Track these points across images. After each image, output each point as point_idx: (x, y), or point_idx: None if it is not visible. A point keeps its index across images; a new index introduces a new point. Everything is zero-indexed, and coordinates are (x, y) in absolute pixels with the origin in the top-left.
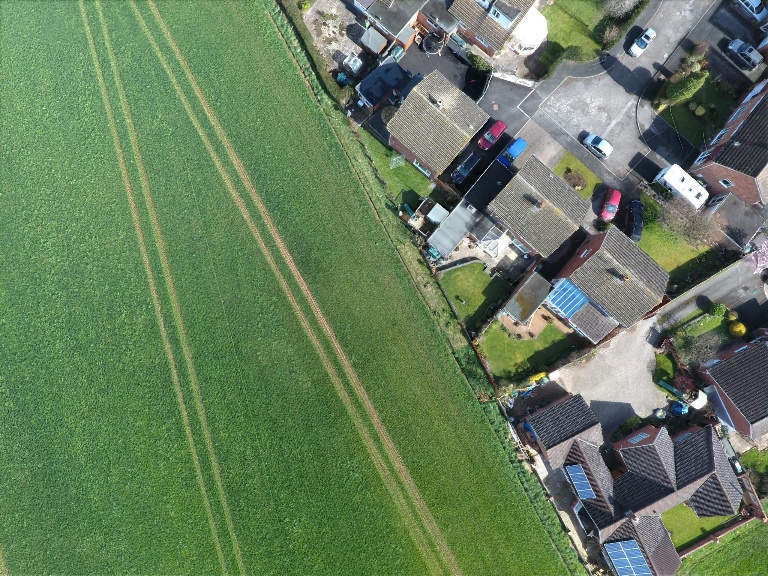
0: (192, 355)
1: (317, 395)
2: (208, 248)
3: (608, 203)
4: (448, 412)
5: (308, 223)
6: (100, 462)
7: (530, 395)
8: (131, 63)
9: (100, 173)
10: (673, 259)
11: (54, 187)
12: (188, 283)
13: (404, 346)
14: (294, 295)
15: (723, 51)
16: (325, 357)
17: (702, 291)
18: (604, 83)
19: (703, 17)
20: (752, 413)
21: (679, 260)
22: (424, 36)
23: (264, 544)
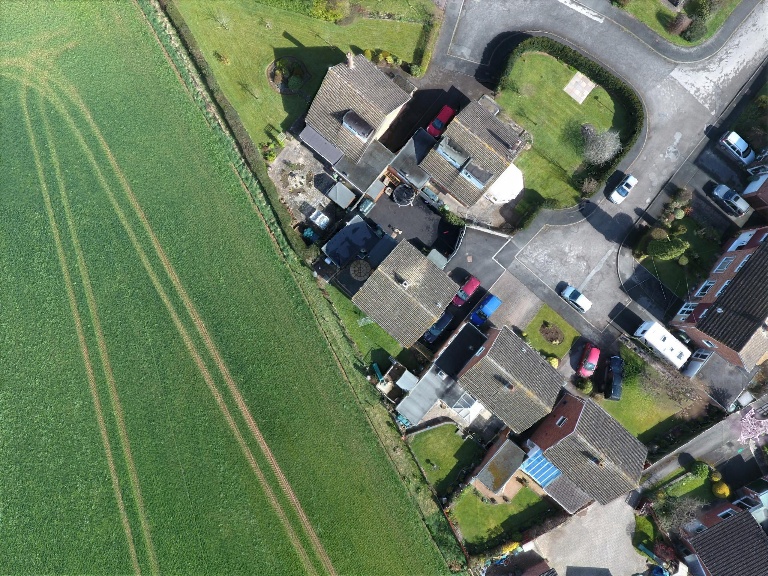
0: (151, 529)
1: (281, 567)
2: (168, 415)
3: (586, 361)
4: None
5: (273, 386)
6: None
7: (503, 564)
8: (89, 222)
9: (56, 339)
10: (654, 415)
11: (8, 355)
12: (147, 453)
13: (372, 513)
14: (258, 462)
15: (708, 195)
16: (290, 527)
17: (685, 448)
18: (583, 231)
19: (688, 159)
20: None
21: (661, 416)
22: (395, 186)
23: None
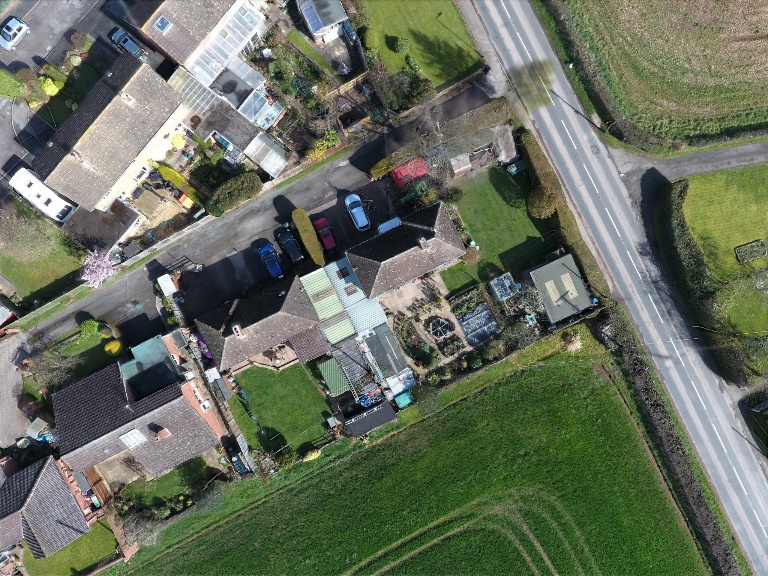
0: None
1: None
2: None
3: None
4: None
5: None
6: None
7: None
8: None
9: None
10: (50, 272)
11: None
12: None
13: None
14: None
15: (113, 42)
16: None
17: (83, 306)
18: None
19: (94, 5)
20: (68, 444)
21: (57, 273)
22: None
23: None
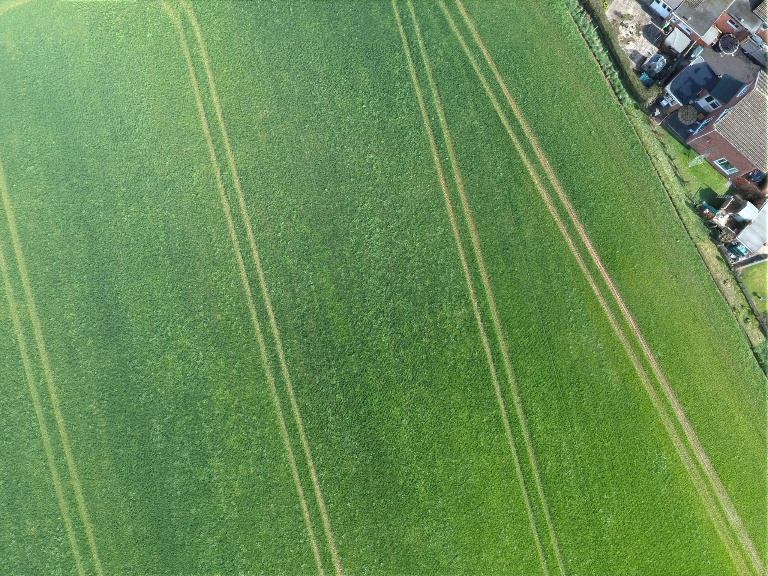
0: (508, 349)
1: (626, 389)
2: (520, 244)
3: None
4: (747, 406)
5: (612, 220)
6: (425, 453)
7: None
8: (443, 62)
9: (417, 170)
10: None
11: (375, 184)
12: (503, 278)
13: (705, 341)
14: (601, 291)
15: None
16: (631, 352)
17: None
18: None
19: None
20: None
21: None
22: (719, 36)
23: (580, 534)
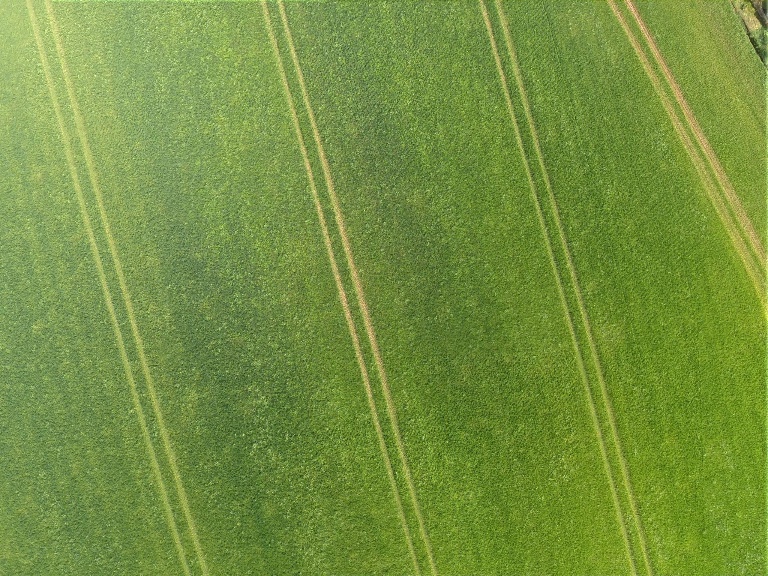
0: (508, 23)
1: (624, 67)
2: None
3: None
4: (744, 90)
5: None
6: (427, 118)
7: None
8: None
9: None
10: None
11: None
12: None
13: (702, 26)
14: None
15: None
16: (629, 32)
17: None
18: None
19: None
20: None
21: None
22: None
23: (580, 203)
